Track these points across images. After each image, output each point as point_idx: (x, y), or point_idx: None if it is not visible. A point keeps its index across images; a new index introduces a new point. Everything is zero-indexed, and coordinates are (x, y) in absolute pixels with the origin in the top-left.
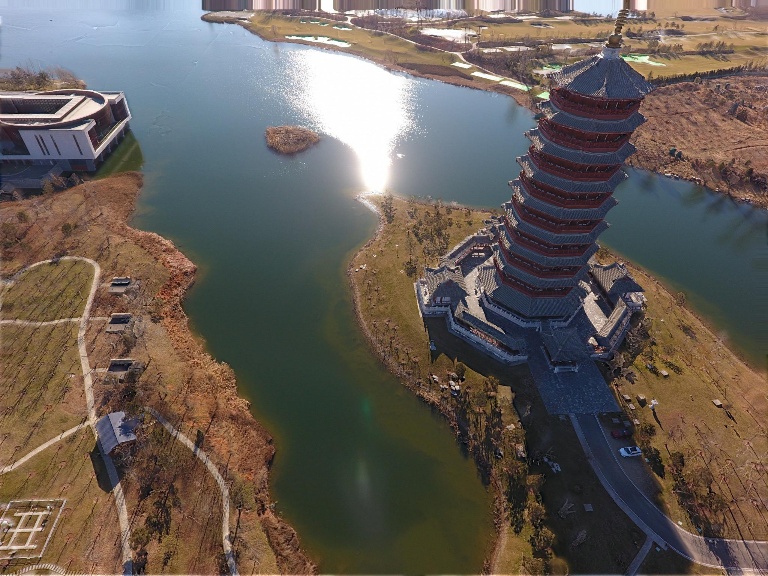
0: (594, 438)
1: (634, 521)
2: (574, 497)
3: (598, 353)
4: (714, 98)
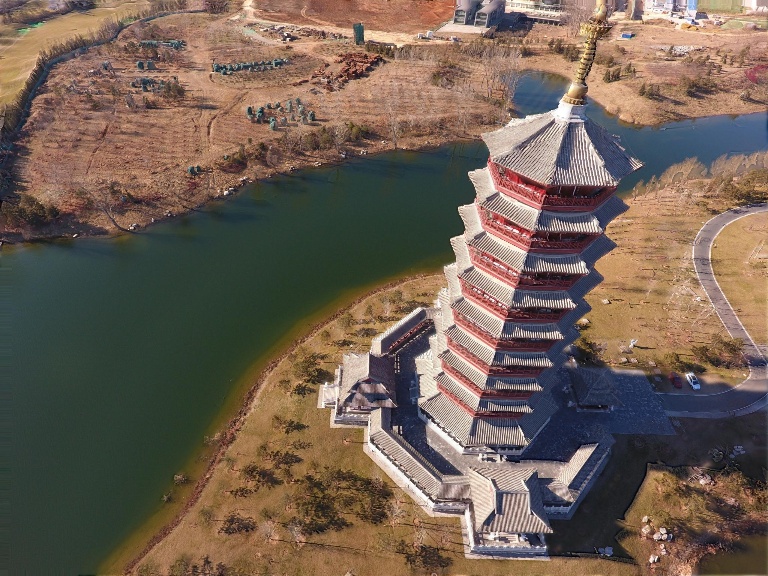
0: (688, 404)
1: (763, 406)
2: (766, 444)
3: (572, 361)
4: (98, 100)
